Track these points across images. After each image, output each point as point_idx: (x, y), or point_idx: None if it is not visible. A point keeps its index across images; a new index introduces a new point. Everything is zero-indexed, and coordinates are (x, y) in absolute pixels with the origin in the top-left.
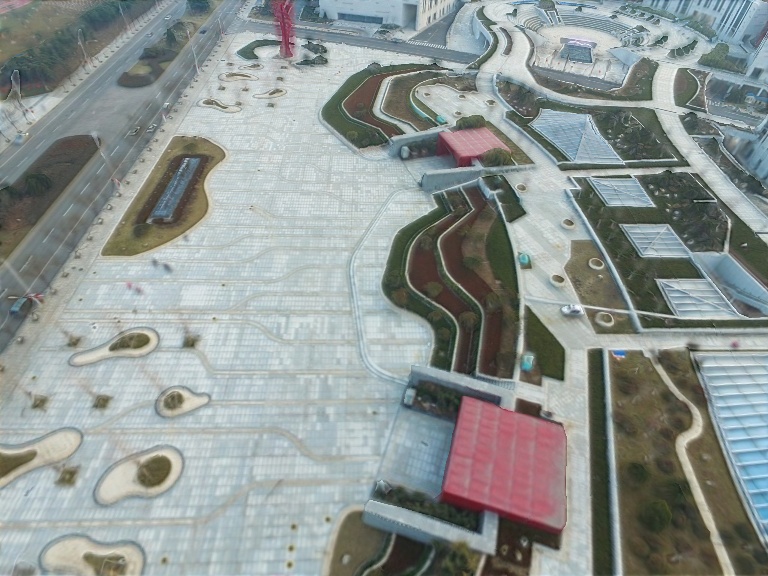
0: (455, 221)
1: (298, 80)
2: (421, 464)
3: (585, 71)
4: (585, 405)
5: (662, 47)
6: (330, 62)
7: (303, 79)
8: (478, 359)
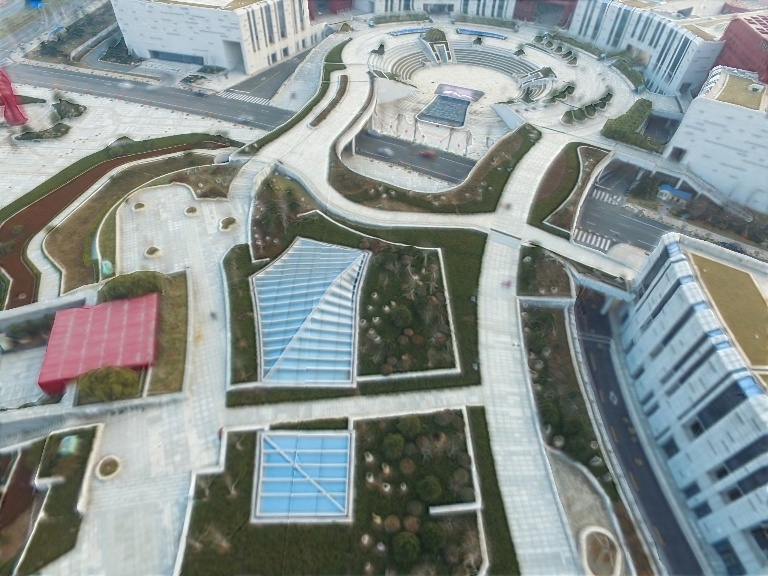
0: None
1: None
2: None
3: (440, 143)
4: None
5: (563, 103)
6: (73, 133)
7: (2, 166)
8: None
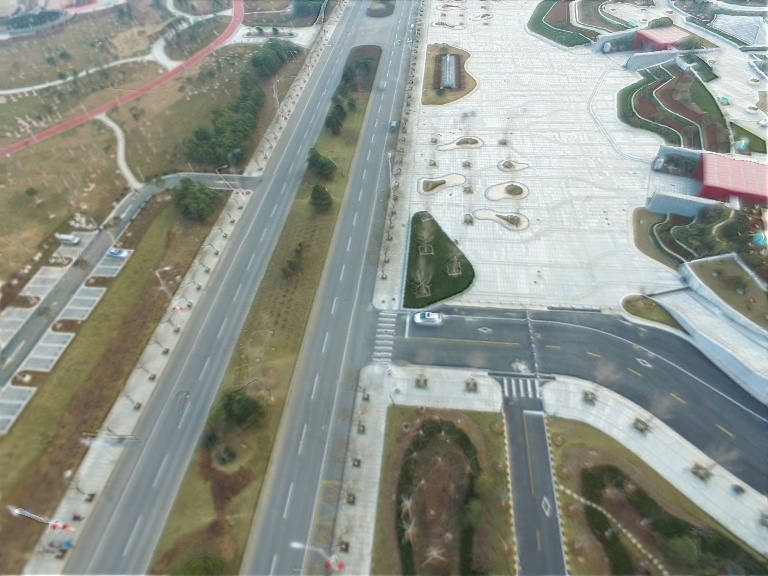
0: (661, 84)
1: (498, 8)
2: (674, 192)
3: None
4: None
5: None
6: None
7: (501, 7)
8: (702, 146)
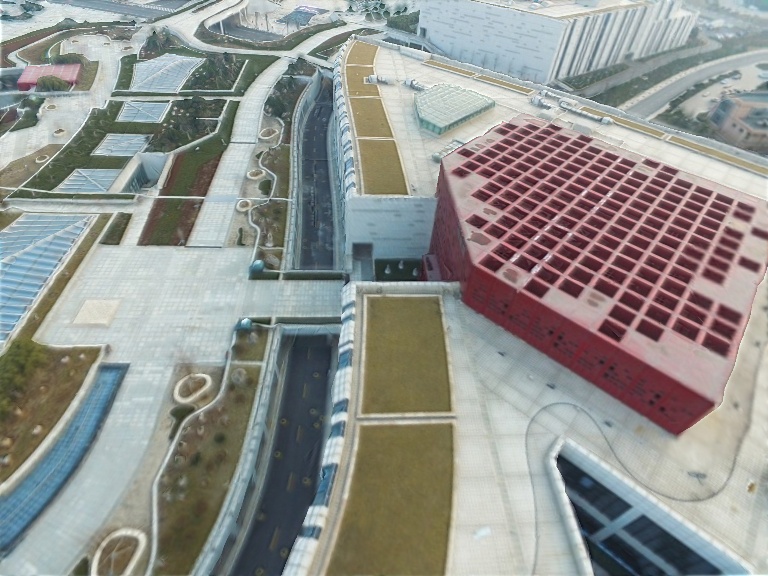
0: None
1: None
2: None
3: (283, 31)
4: None
5: None
6: (35, 18)
7: None
8: None
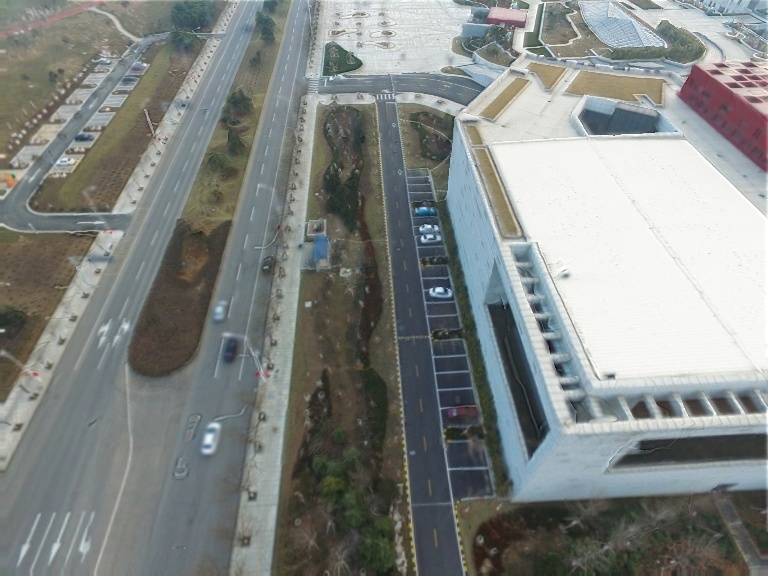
0: None
1: None
2: None
3: None
4: (536, 12)
5: None
6: None
7: None
8: None
